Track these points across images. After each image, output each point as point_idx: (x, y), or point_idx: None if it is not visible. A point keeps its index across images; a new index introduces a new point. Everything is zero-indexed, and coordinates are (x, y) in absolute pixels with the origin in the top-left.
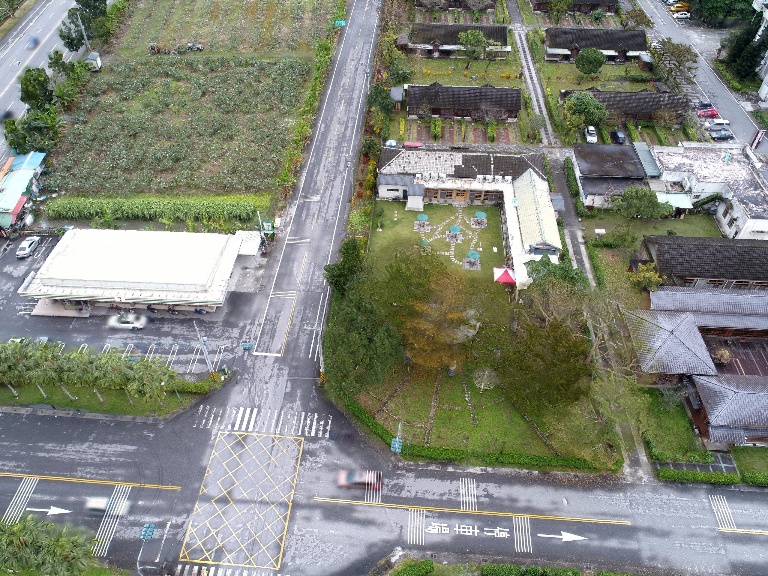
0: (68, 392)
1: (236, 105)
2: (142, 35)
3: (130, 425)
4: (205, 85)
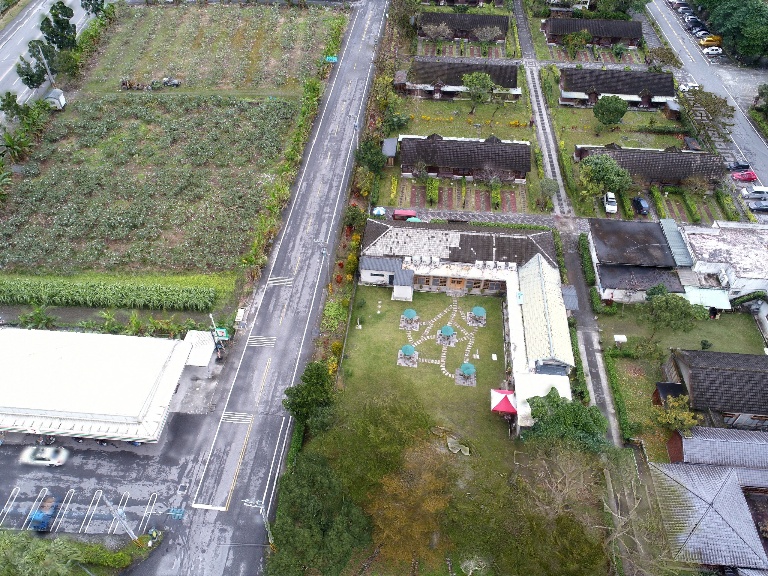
0: None
1: (209, 156)
2: (115, 66)
3: None
4: (177, 130)
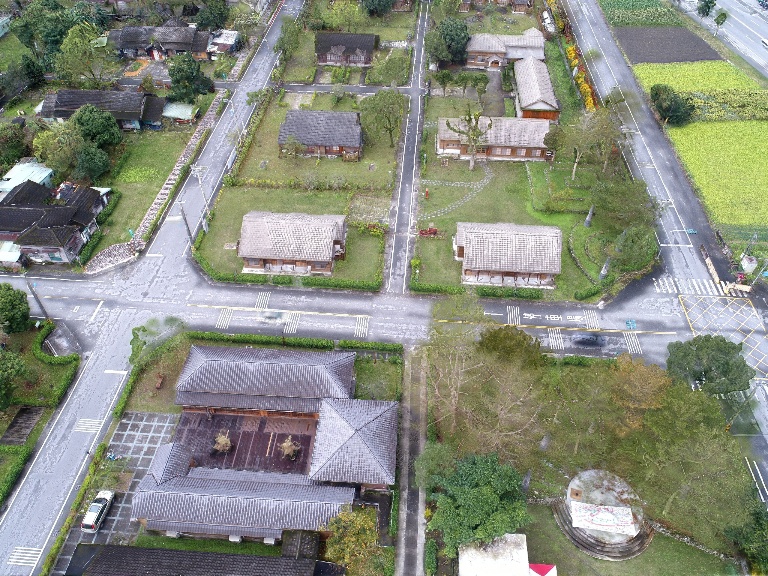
0: None
1: None
2: None
3: None
4: None
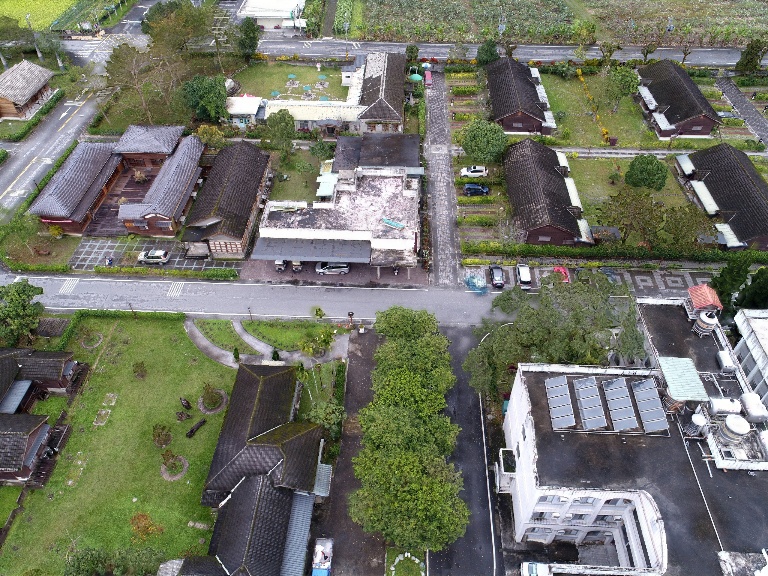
0: (206, 6)
1: None
2: None
3: None
4: (514, 3)
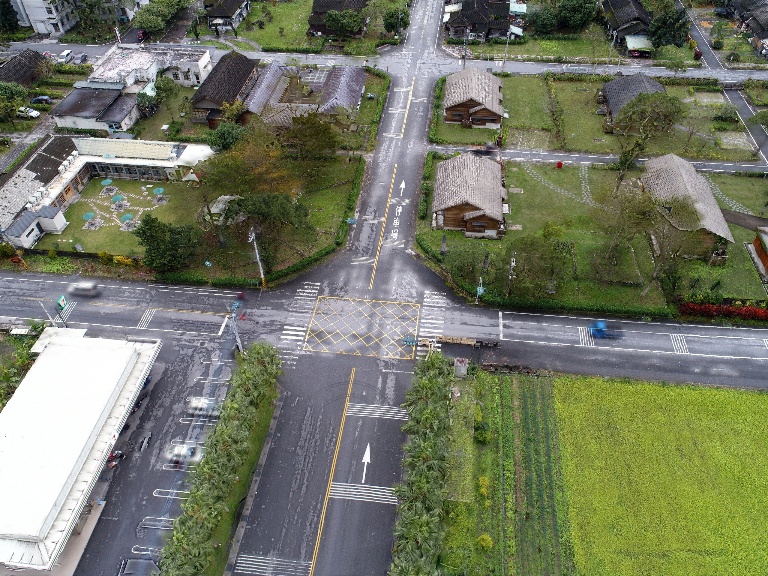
0: None
1: None
2: None
3: (283, 419)
4: None
